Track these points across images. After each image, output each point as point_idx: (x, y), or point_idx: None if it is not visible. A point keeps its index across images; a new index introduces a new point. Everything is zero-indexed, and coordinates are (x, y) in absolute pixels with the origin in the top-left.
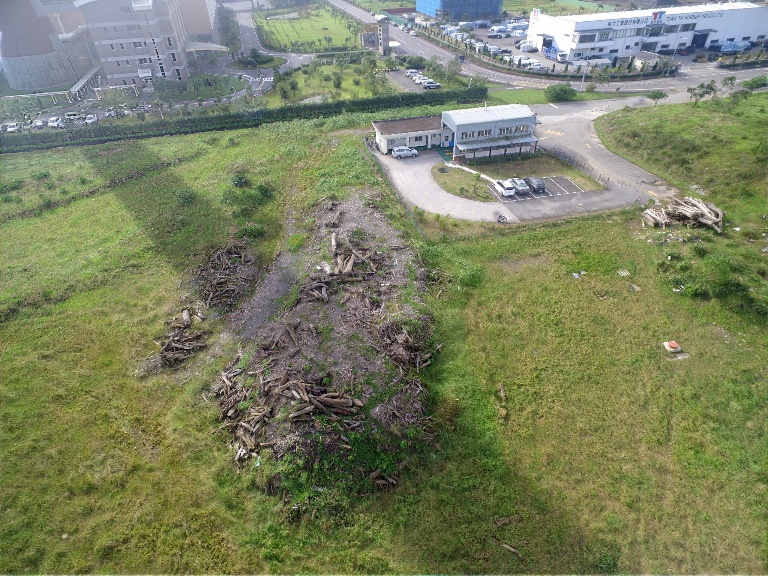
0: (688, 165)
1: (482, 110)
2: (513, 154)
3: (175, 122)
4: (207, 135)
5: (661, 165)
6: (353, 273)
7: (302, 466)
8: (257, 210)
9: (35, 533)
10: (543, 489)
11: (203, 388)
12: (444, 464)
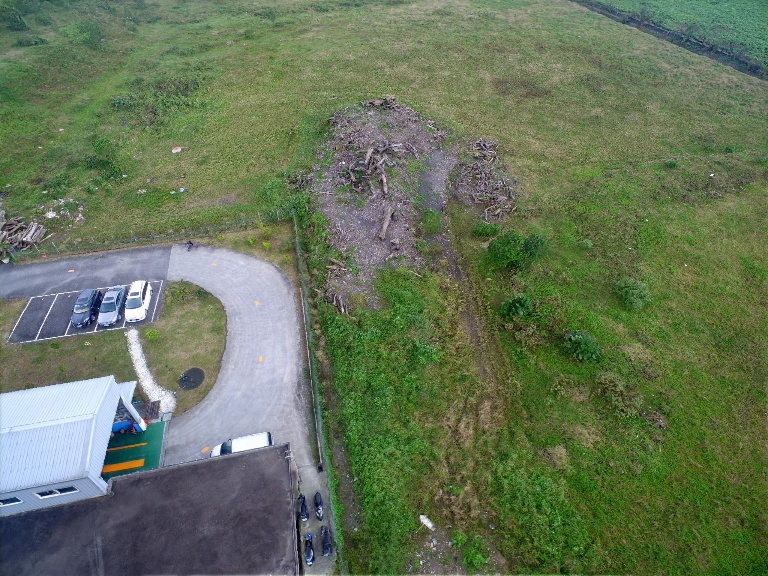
0: None
1: None
2: None
3: None
4: None
5: None
6: None
7: None
8: (504, 275)
9: None
10: None
11: None
12: None
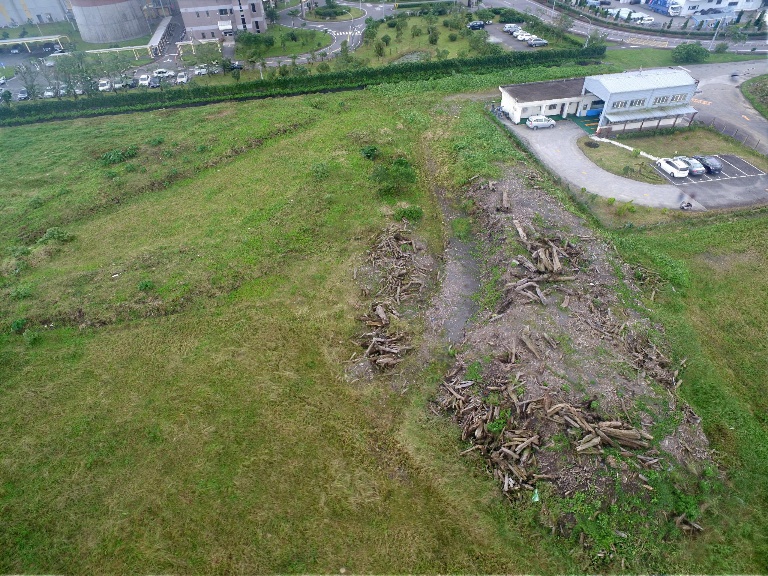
0: None
1: (635, 76)
2: (663, 127)
3: (276, 83)
4: (315, 98)
5: None
6: (563, 271)
7: (599, 507)
8: (402, 188)
9: (309, 565)
10: None
11: (429, 400)
12: (745, 507)
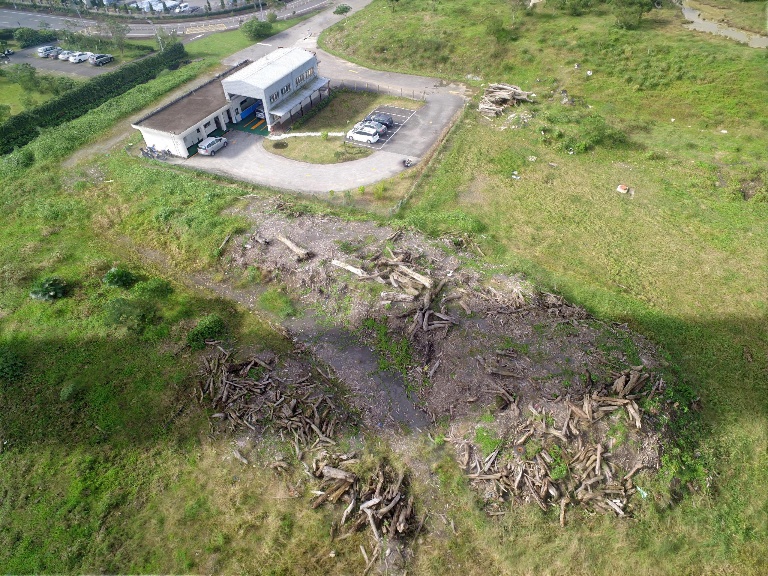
0: (450, 60)
1: (266, 65)
2: (312, 103)
3: None
4: None
5: (429, 68)
6: None
7: None
8: None
9: None
10: (724, 321)
11: (481, 508)
12: None
